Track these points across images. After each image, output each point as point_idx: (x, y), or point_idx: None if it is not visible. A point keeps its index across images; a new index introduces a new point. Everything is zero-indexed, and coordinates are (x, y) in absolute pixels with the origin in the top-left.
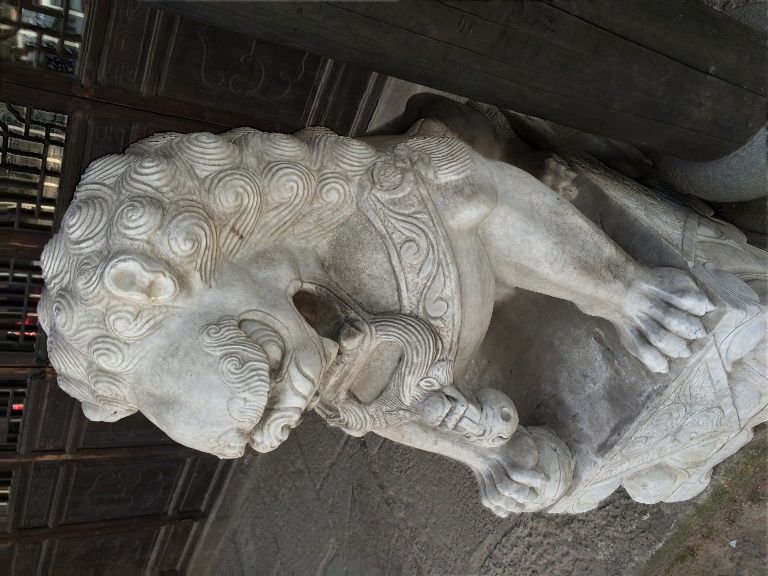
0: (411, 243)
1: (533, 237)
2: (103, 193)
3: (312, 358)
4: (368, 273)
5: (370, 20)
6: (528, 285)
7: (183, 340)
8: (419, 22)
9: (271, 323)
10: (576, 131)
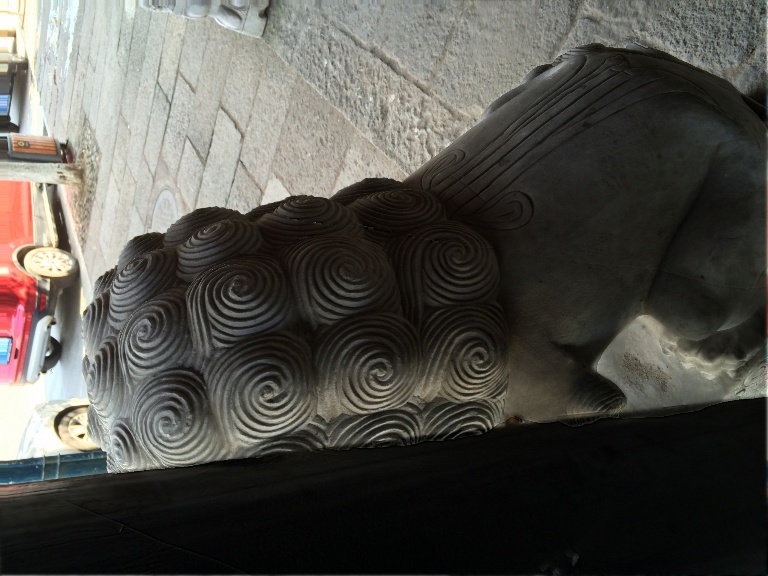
0: None
1: None
2: (158, 466)
3: None
4: None
5: None
6: None
7: None
8: None
9: None
10: None
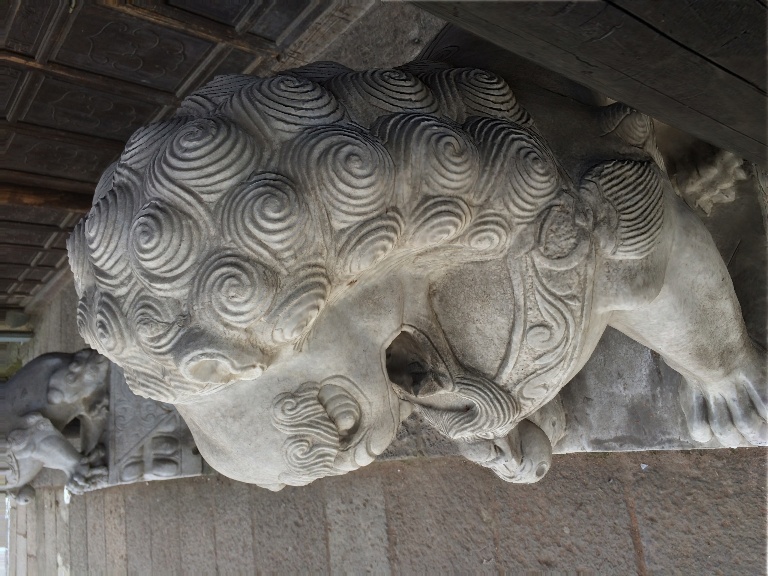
0: (546, 330)
1: (672, 323)
2: (196, 213)
3: (385, 438)
4: (478, 327)
5: (673, 101)
6: (630, 336)
7: (251, 407)
8: (734, 117)
9: (355, 395)
10: None
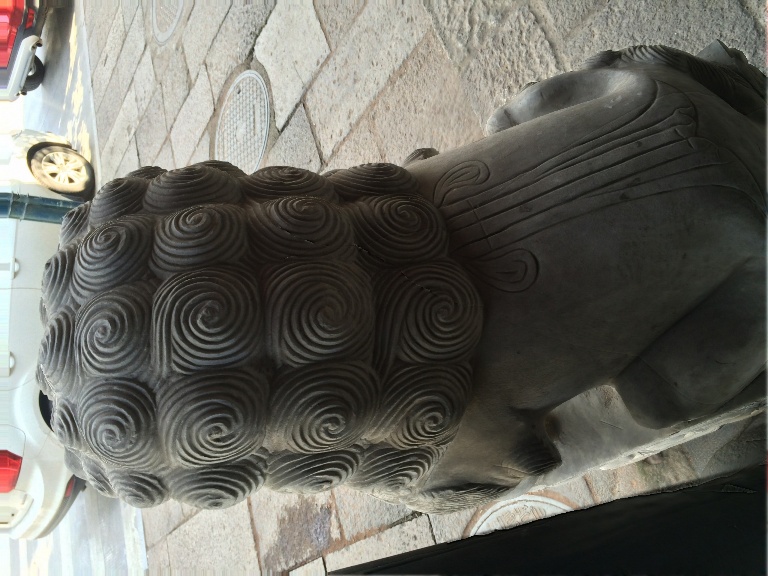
0: None
1: None
2: None
3: None
4: None
5: None
6: None
7: None
8: None
9: None
10: None
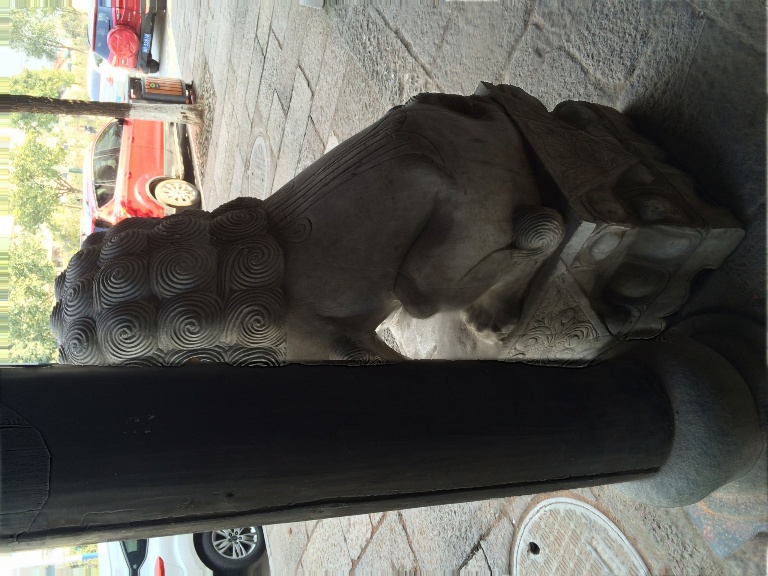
0: None
1: None
2: None
3: None
4: None
5: None
6: None
7: None
8: None
9: None
10: (674, 231)
